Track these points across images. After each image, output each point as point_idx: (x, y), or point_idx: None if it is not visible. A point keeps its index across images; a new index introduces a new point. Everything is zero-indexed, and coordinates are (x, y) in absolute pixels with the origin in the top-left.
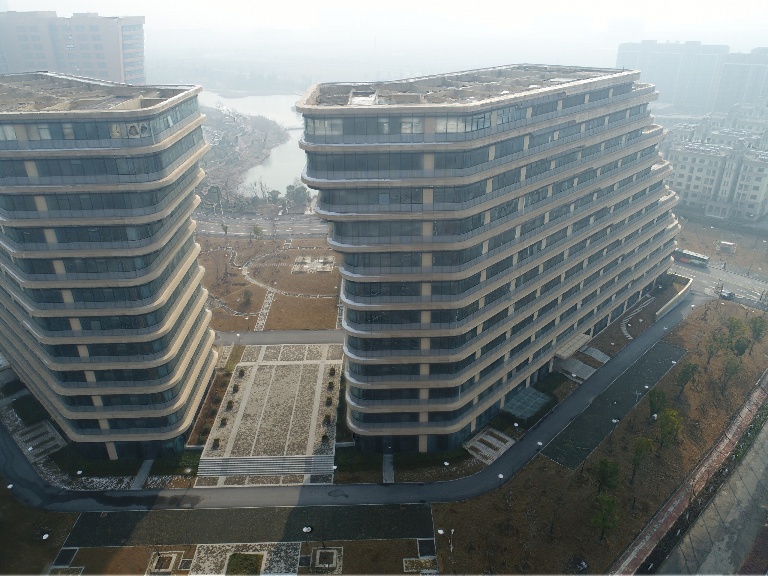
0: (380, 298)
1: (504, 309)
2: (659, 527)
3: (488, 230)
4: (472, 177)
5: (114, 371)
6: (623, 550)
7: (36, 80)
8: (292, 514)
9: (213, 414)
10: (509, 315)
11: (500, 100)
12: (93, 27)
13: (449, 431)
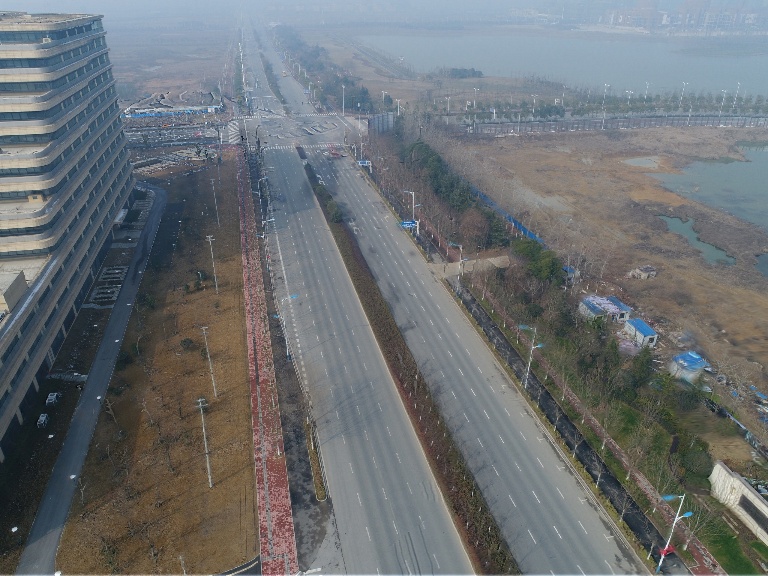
0: None
1: None
2: None
3: None
4: None
5: None
6: None
7: None
8: None
9: None
10: None
11: None
12: None
13: None
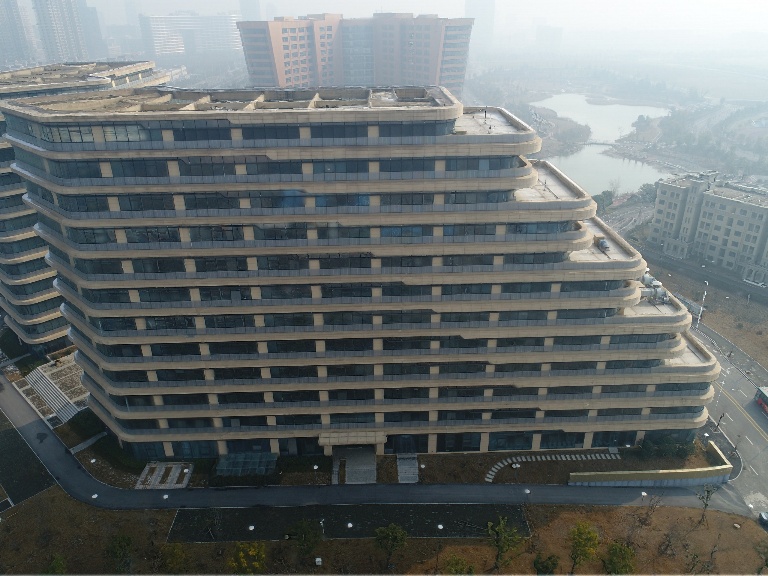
0: (63, 283)
1: (184, 344)
2: None
3: (125, 250)
4: (66, 188)
5: None
6: None
7: (117, 67)
8: (6, 431)
9: None
10: (203, 355)
11: (88, 115)
12: (427, 27)
13: (121, 437)
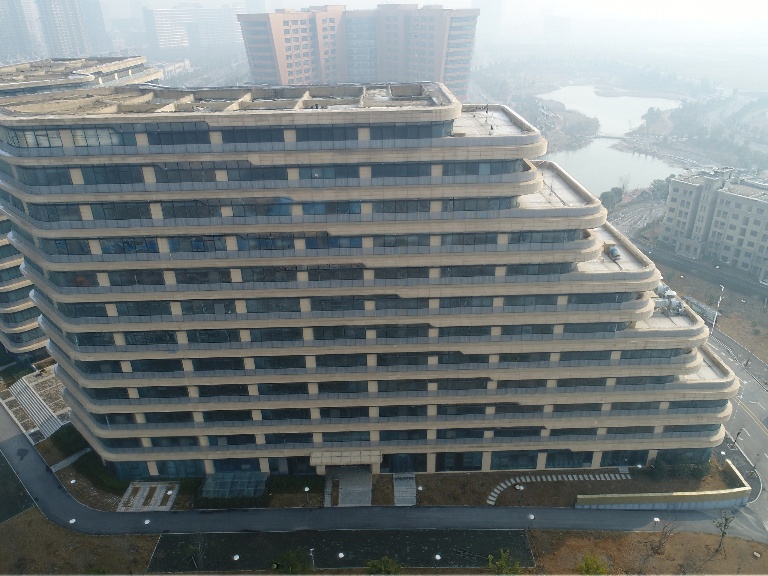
0: (39, 295)
1: (166, 360)
2: None
3: (100, 261)
4: (34, 196)
5: None
6: None
7: None
8: None
9: None
10: (187, 371)
11: (54, 118)
12: (432, 18)
13: (102, 456)
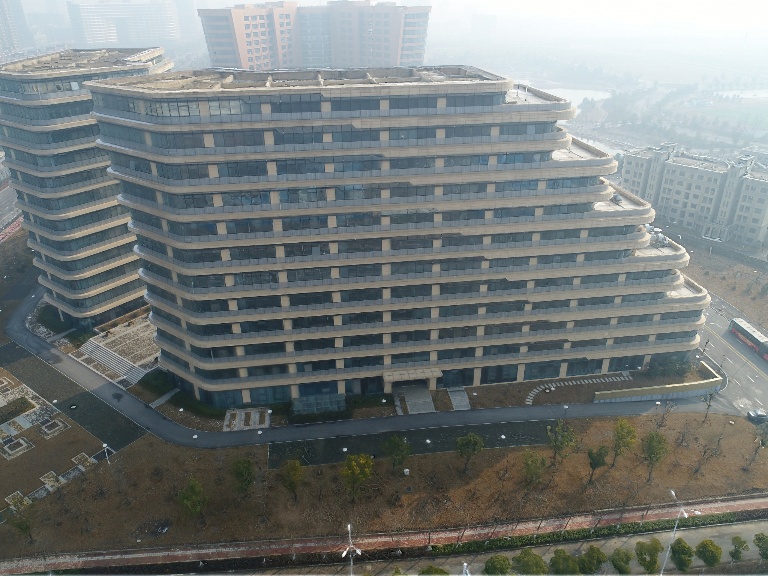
0: (147, 249)
1: (268, 297)
2: (263, 549)
3: (221, 213)
4: (173, 158)
5: (50, 257)
6: (207, 542)
7: (132, 53)
8: (80, 394)
9: (133, 317)
10: (284, 306)
11: (198, 92)
12: (386, 14)
13: (204, 387)
